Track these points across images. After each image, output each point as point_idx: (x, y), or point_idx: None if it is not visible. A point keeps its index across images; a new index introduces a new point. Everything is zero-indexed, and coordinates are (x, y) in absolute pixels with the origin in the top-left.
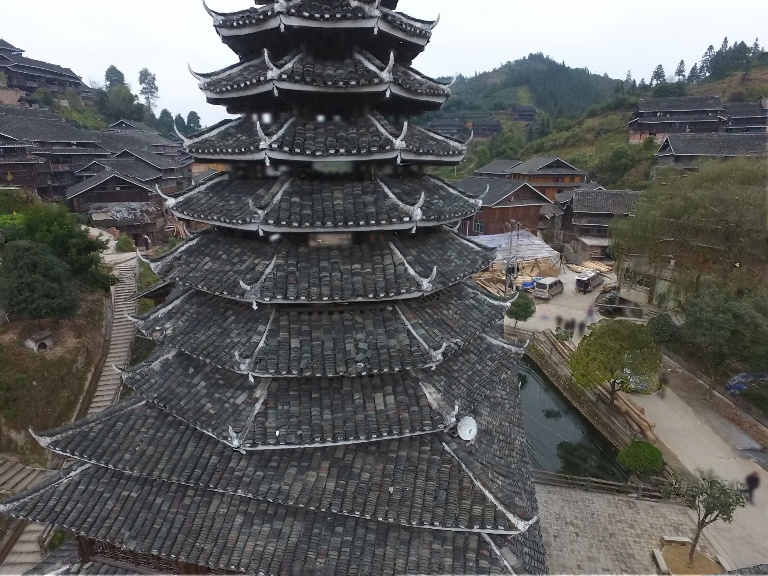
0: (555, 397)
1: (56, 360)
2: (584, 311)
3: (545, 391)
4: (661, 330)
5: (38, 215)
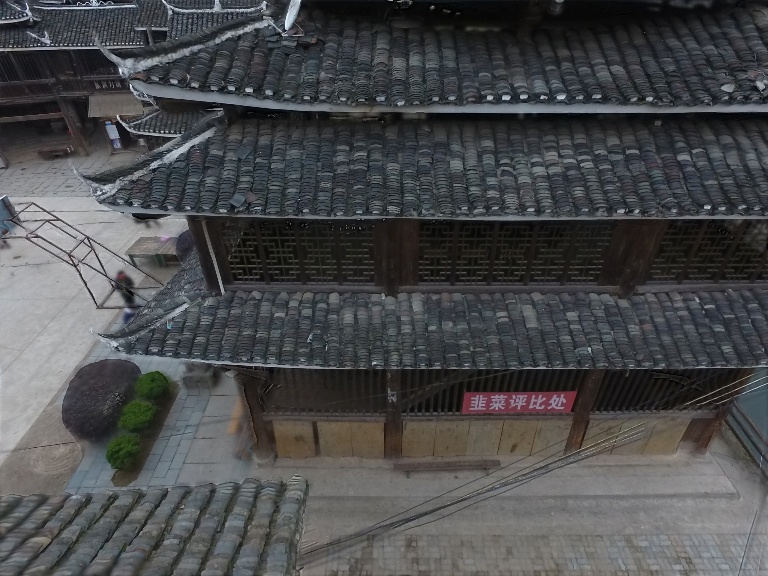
0: None
1: None
2: None
3: None
4: None
5: None
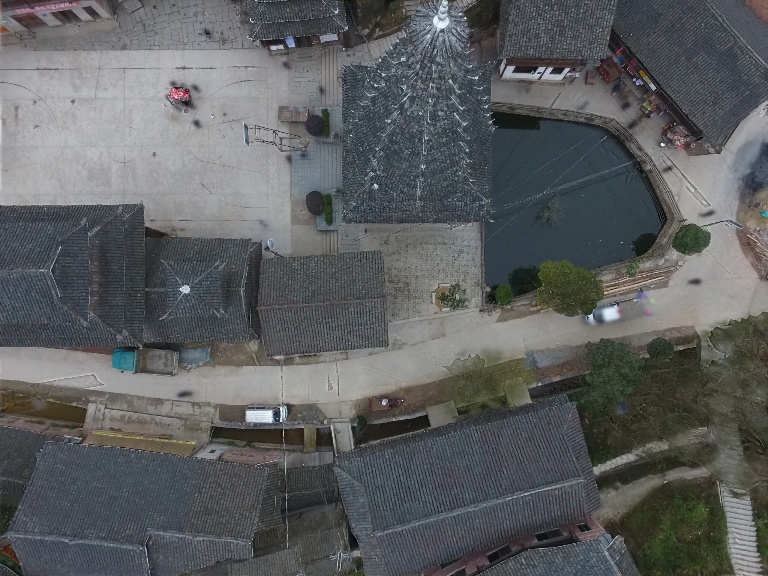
0: None
1: None
2: (746, 312)
3: None
4: (652, 346)
5: None
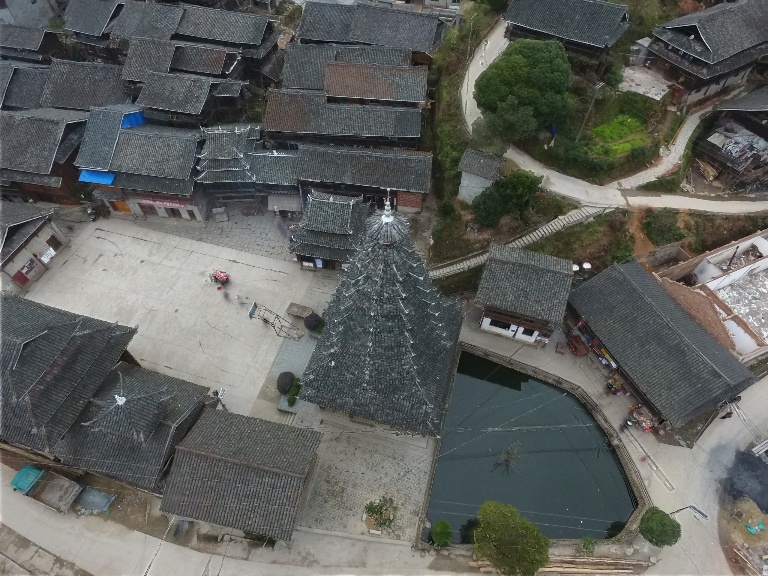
0: None
1: (465, 239)
2: None
3: None
4: None
5: (514, 179)
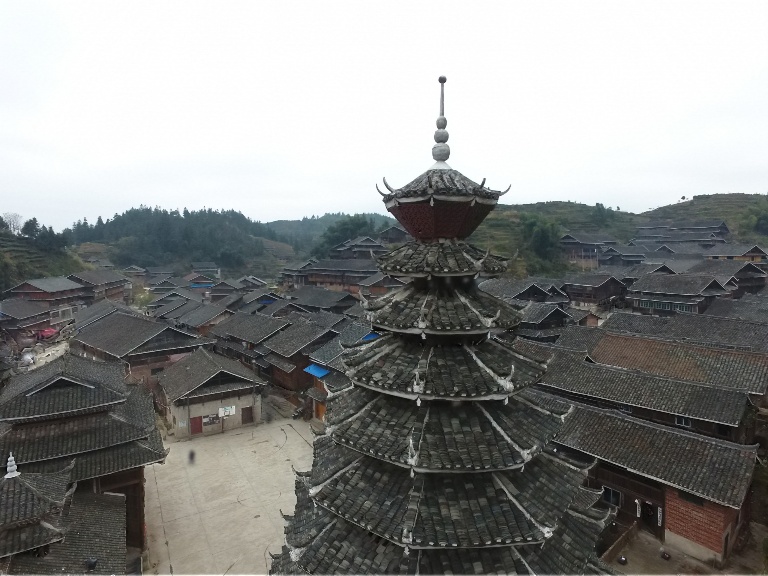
0: None
1: None
2: None
3: None
4: None
5: None
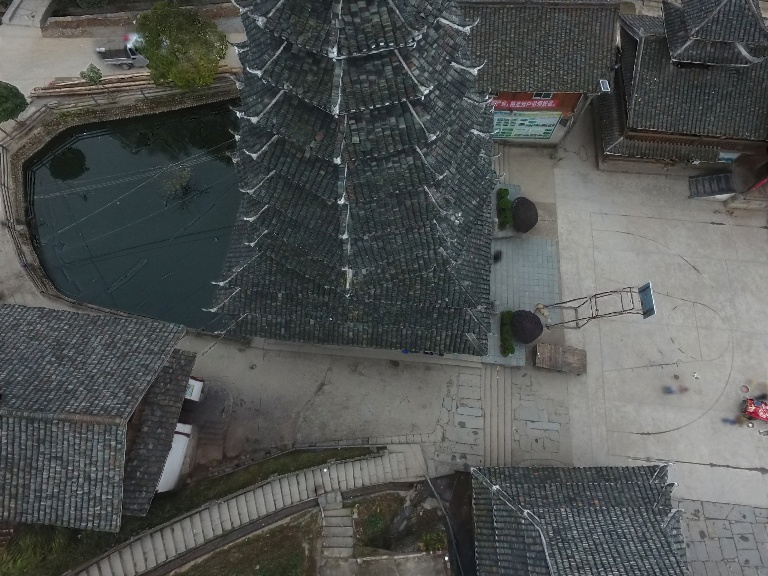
0: (137, 126)
1: None
2: None
3: (119, 133)
4: None
5: None
